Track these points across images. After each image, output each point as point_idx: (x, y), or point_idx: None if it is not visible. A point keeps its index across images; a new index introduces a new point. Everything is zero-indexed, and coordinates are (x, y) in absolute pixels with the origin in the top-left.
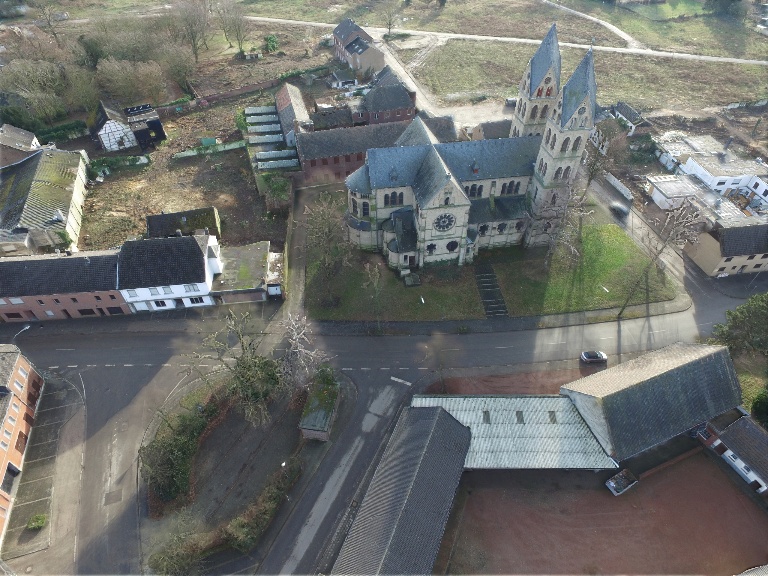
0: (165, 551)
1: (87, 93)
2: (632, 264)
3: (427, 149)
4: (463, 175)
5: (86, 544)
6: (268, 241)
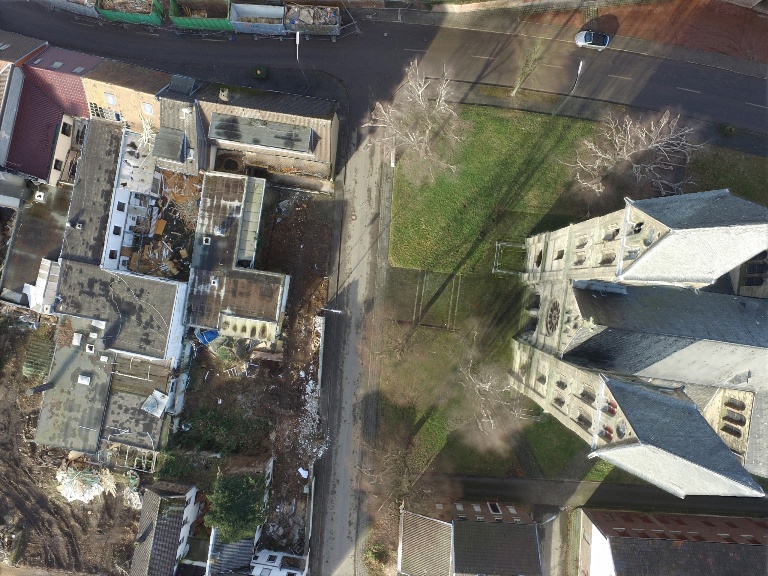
0: None
1: None
2: (434, 171)
3: None
4: (767, 307)
5: None
6: None
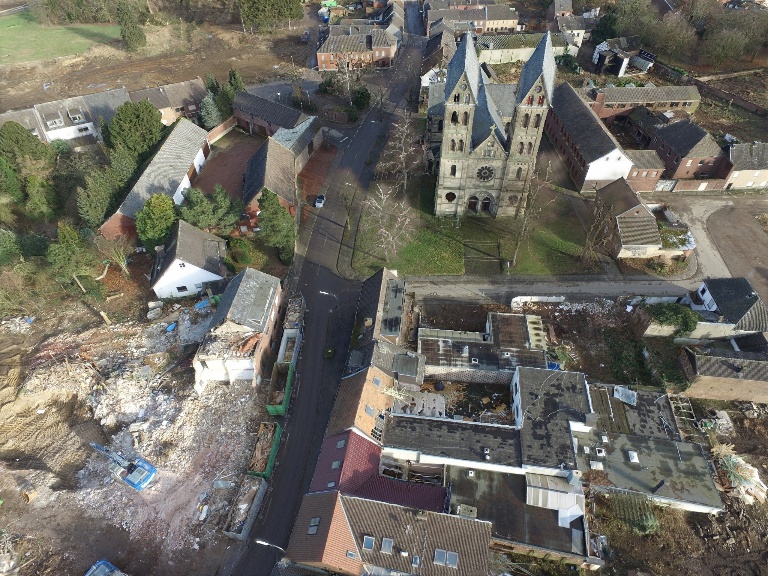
0: (303, 92)
1: (649, 31)
2: (399, 256)
3: None
4: None
5: None
6: None
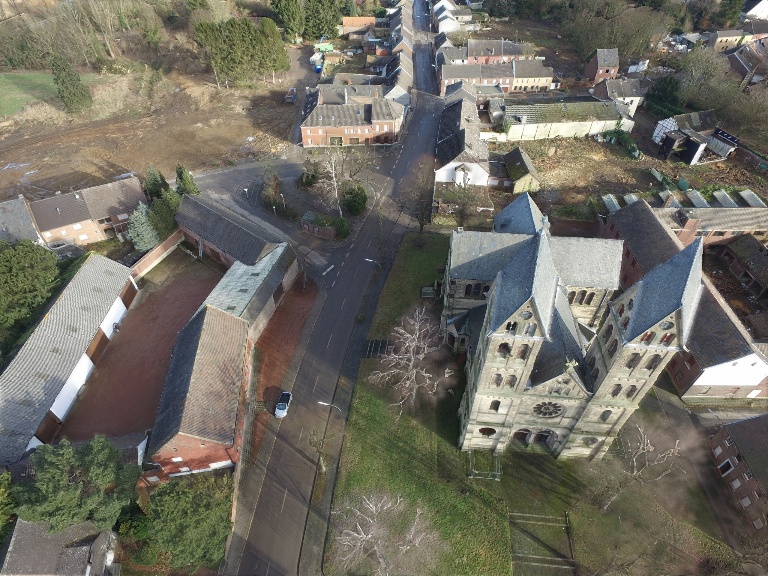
0: (280, 183)
1: (726, 102)
2: None
3: (532, 234)
4: None
5: (298, 165)
6: (493, 208)
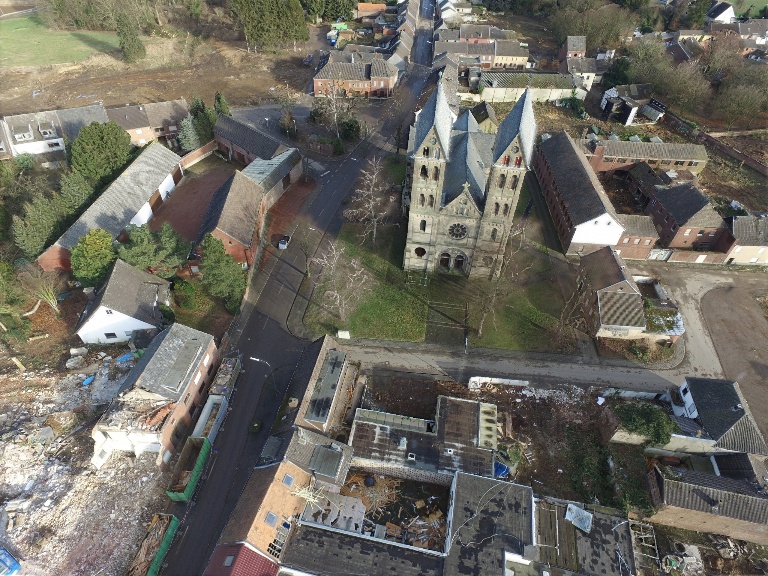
0: None
1: (662, 79)
2: (356, 314)
3: None
4: None
5: (309, 108)
6: None
